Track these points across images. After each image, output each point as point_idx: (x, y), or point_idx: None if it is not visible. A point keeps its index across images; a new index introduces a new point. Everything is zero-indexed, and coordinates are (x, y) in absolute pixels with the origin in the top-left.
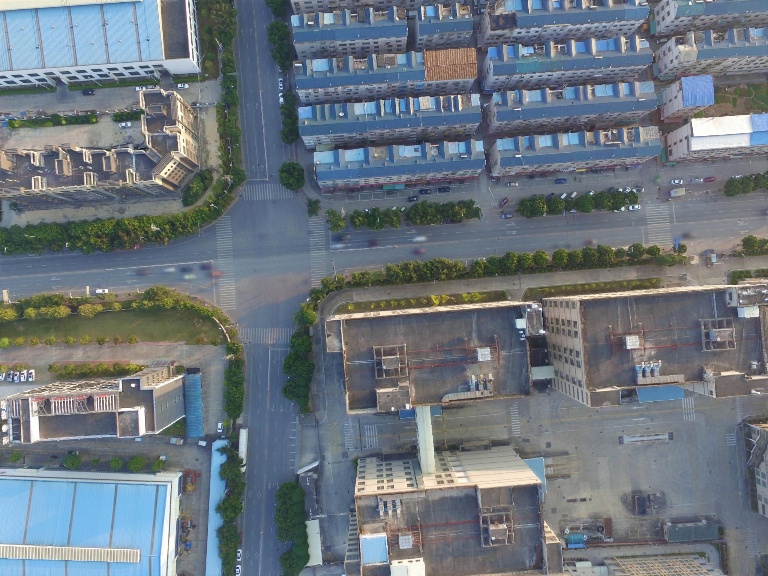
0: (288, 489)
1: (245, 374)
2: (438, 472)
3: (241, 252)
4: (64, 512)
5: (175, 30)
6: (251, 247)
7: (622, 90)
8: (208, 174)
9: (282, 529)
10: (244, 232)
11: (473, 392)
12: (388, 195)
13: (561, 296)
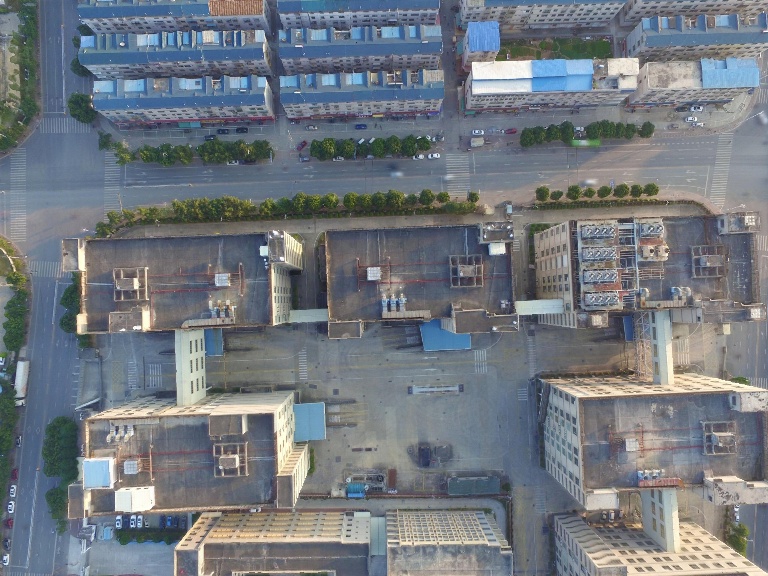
0: (59, 423)
1: (31, 307)
2: (193, 405)
3: (34, 184)
4: None
5: None
6: (45, 180)
7: (408, 32)
8: (2, 104)
9: (48, 463)
10: (39, 164)
11: (214, 319)
12: (186, 133)
13: None
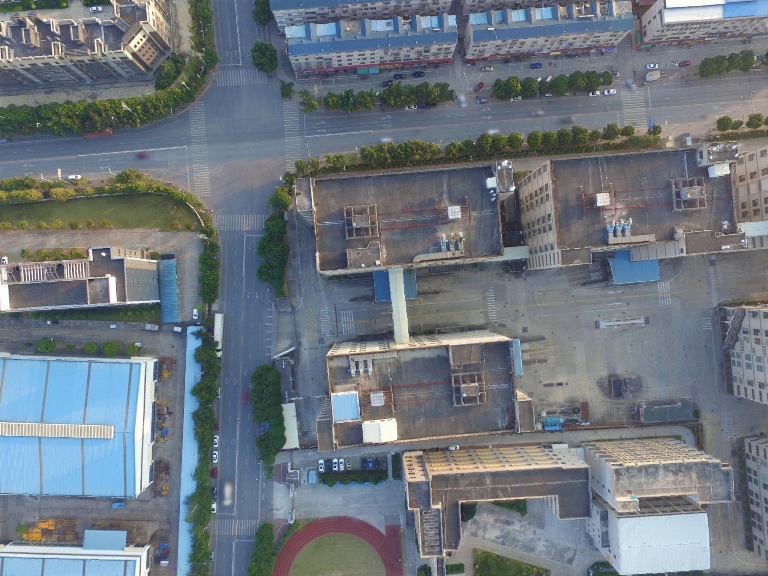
0: (263, 371)
1: (220, 261)
2: (412, 342)
3: (215, 138)
4: (37, 390)
5: None
6: (225, 133)
7: None
8: (180, 58)
9: (258, 409)
10: (218, 118)
11: (444, 252)
12: (362, 80)
13: None
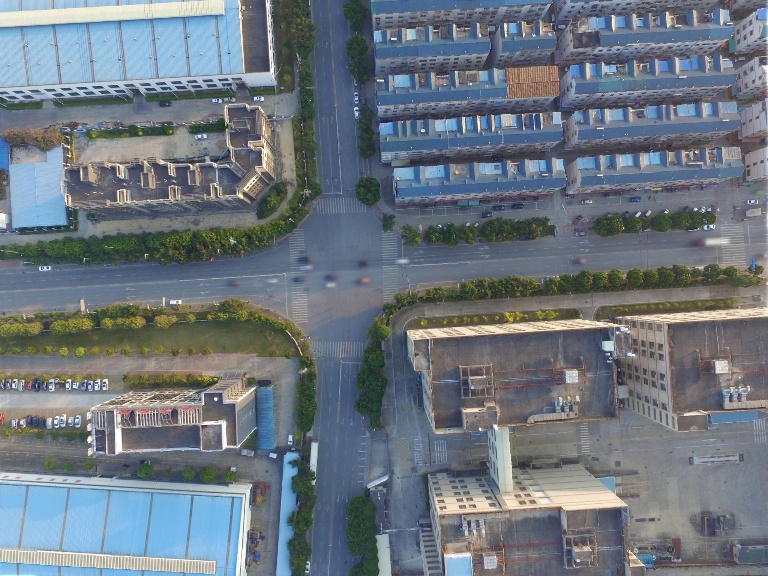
0: (360, 503)
1: (316, 387)
2: (516, 491)
3: (314, 265)
4: (141, 522)
5: (255, 43)
6: (324, 261)
7: (705, 110)
8: (283, 187)
9: (354, 543)
10: (317, 245)
11: (558, 413)
12: (461, 211)
13: (634, 315)
